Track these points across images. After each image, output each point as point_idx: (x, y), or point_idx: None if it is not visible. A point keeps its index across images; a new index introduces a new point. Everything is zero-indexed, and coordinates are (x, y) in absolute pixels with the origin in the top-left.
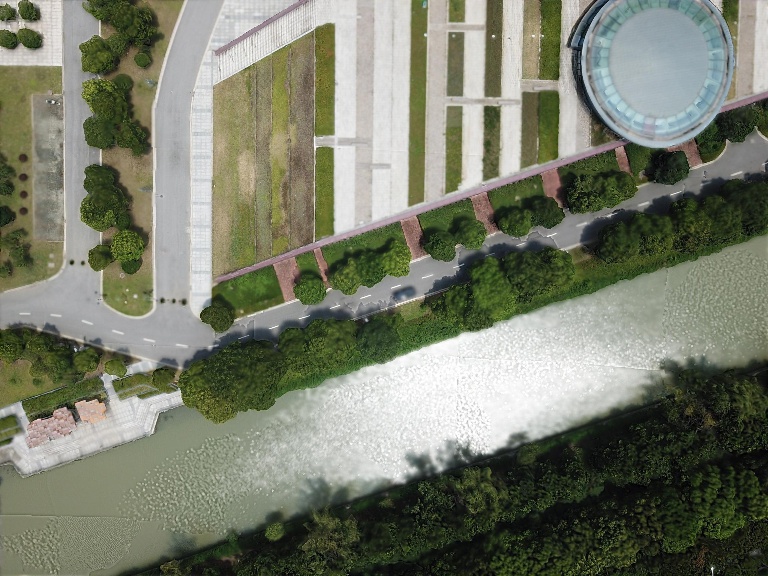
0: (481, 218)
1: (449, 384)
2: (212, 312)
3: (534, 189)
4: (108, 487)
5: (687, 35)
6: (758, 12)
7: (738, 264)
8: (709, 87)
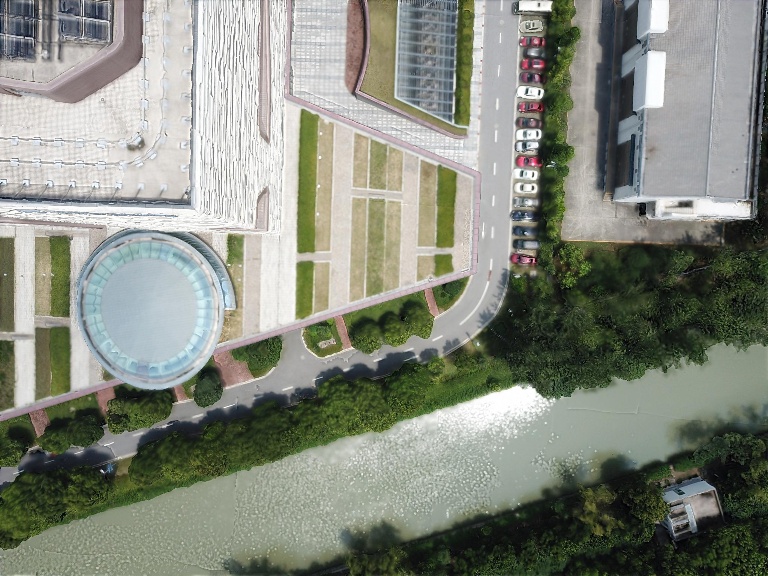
0: (39, 427)
1: None
2: None
3: (88, 401)
4: None
5: (175, 286)
6: (263, 256)
7: (305, 468)
8: (204, 332)
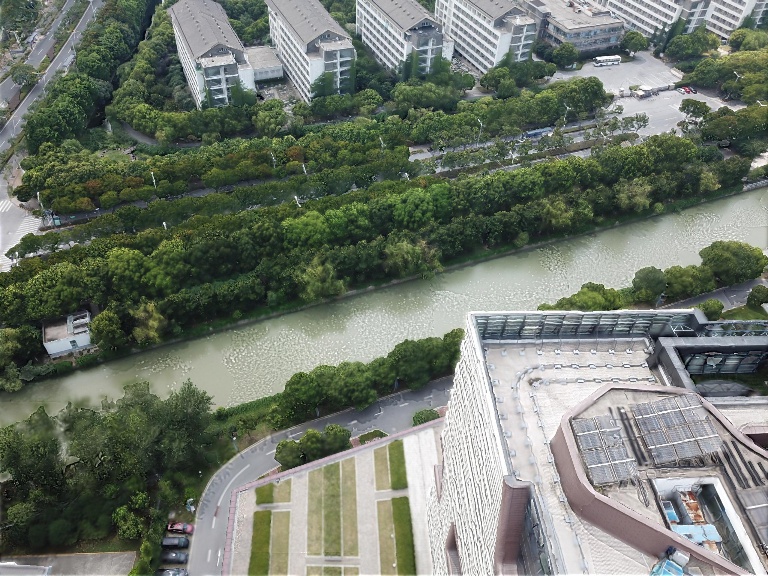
0: None
1: (574, 286)
2: None
3: None
4: (764, 234)
5: None
6: None
7: None
8: None
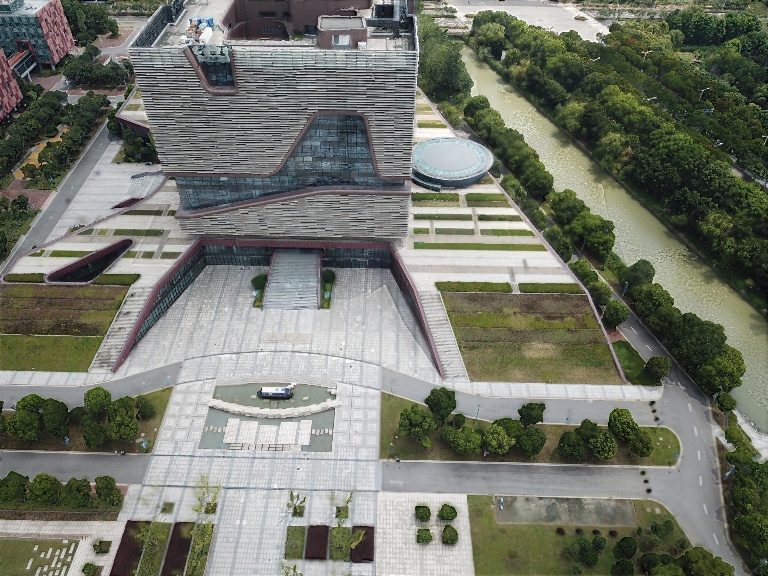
0: None
1: None
2: (657, 361)
3: None
4: None
5: (435, 148)
6: (416, 137)
7: None
8: None
